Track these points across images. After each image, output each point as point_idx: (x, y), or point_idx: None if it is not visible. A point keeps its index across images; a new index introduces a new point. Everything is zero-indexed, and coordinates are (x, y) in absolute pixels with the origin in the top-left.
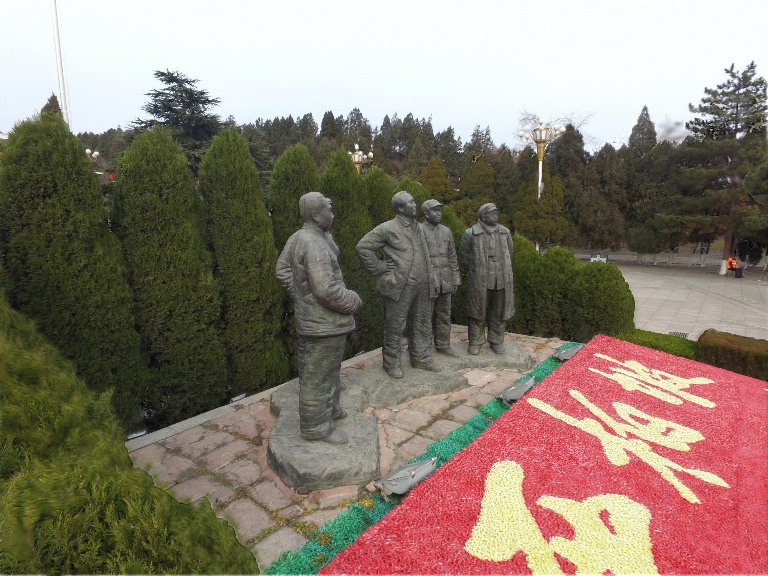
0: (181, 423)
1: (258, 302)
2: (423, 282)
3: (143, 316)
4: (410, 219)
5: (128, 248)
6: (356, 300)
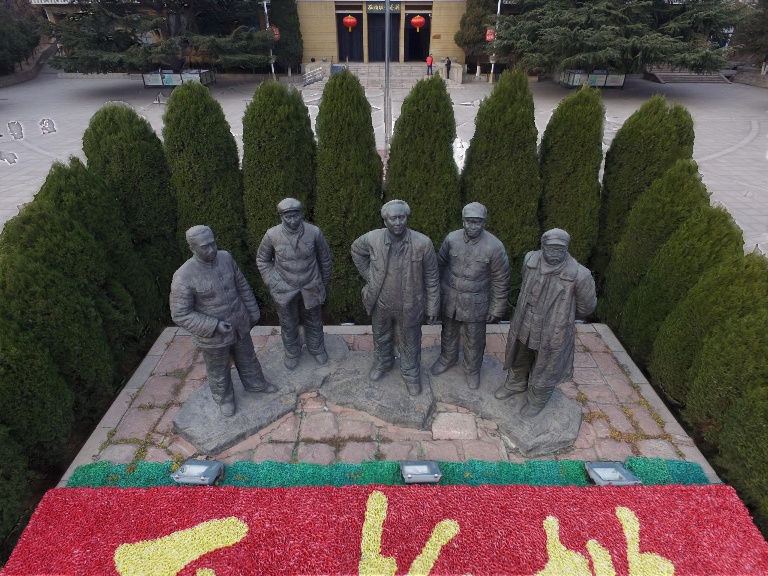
0: None
1: (342, 247)
2: (395, 309)
3: (249, 239)
4: (395, 236)
5: (245, 186)
6: (208, 330)
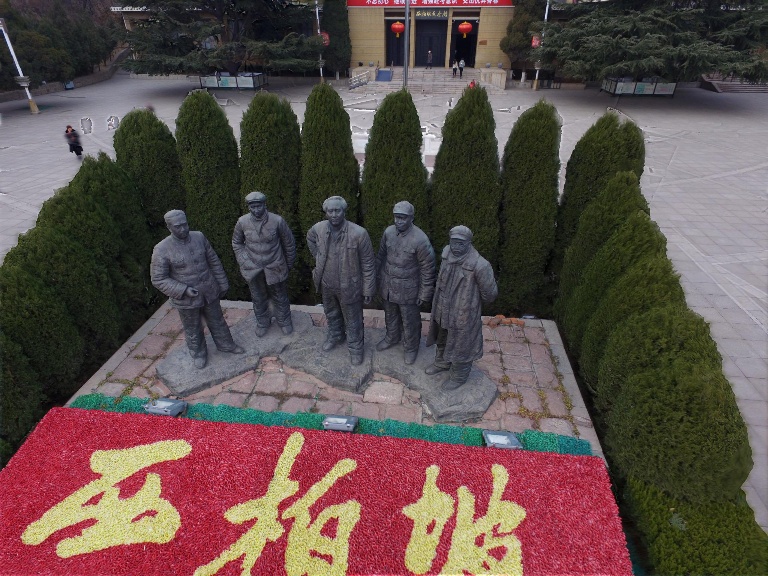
0: (226, 301)
1: None
2: (335, 288)
3: None
4: (334, 226)
5: None
6: (178, 293)
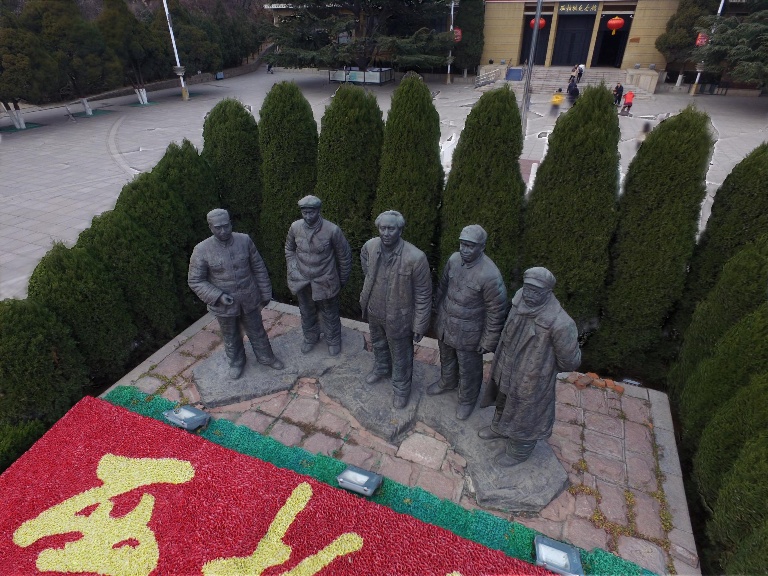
0: (285, 305)
1: None
2: (380, 317)
3: None
4: (386, 246)
5: None
6: (212, 300)
